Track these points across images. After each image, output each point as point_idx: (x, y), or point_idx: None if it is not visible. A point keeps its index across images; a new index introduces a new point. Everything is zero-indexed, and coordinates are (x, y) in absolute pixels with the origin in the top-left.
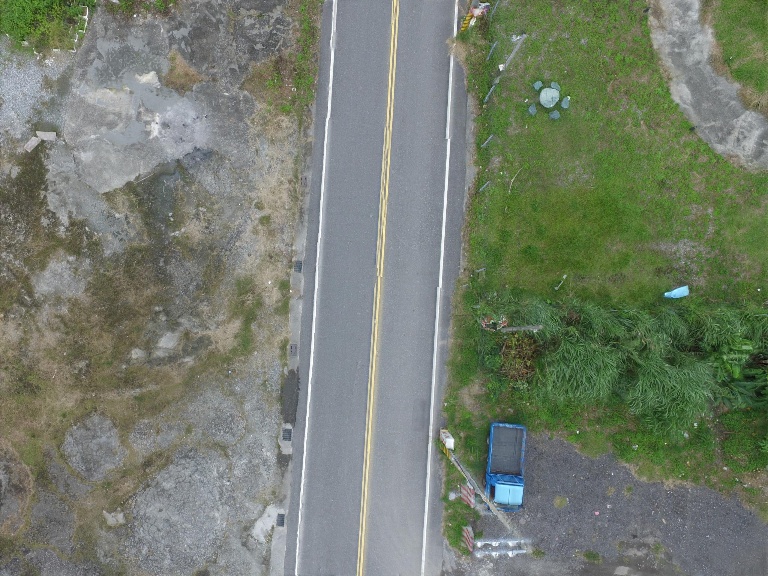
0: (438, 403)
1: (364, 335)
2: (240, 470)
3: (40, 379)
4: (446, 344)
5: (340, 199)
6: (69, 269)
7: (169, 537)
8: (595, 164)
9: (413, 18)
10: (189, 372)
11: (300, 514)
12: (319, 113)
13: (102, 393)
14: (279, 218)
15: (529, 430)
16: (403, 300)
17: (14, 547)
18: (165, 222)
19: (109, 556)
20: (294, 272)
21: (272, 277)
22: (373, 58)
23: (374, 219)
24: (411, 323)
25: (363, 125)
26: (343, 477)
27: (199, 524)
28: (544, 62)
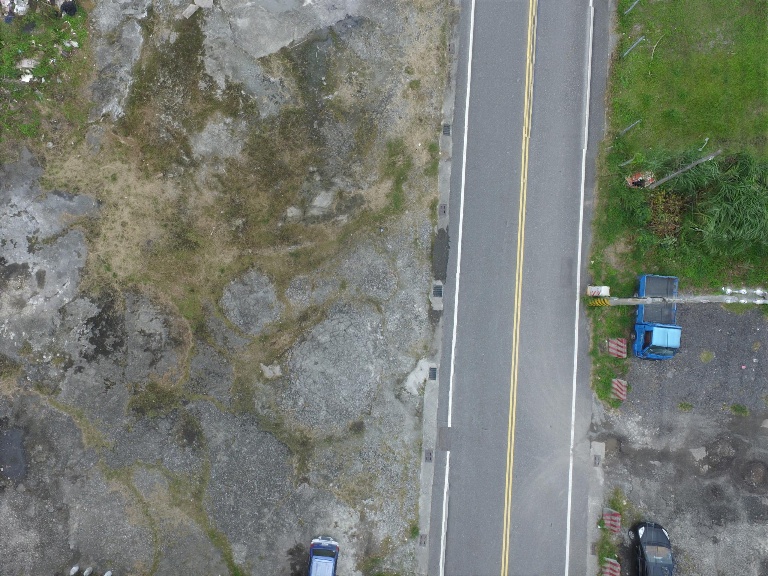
0: (585, 261)
1: (513, 195)
2: (393, 325)
3: (199, 236)
4: (592, 204)
5: (487, 65)
6: (226, 131)
7: (325, 389)
8: (735, 31)
9: None
10: (342, 230)
11: (453, 366)
12: None
13: (258, 250)
14: (428, 82)
15: (675, 286)
16: (550, 161)
17: (174, 398)
18: (318, 86)
19: (266, 407)
20: (443, 135)
21: (422, 139)
22: None
23: (521, 83)
24: (558, 183)
25: None
26: (494, 331)
27: (354, 377)
28: None
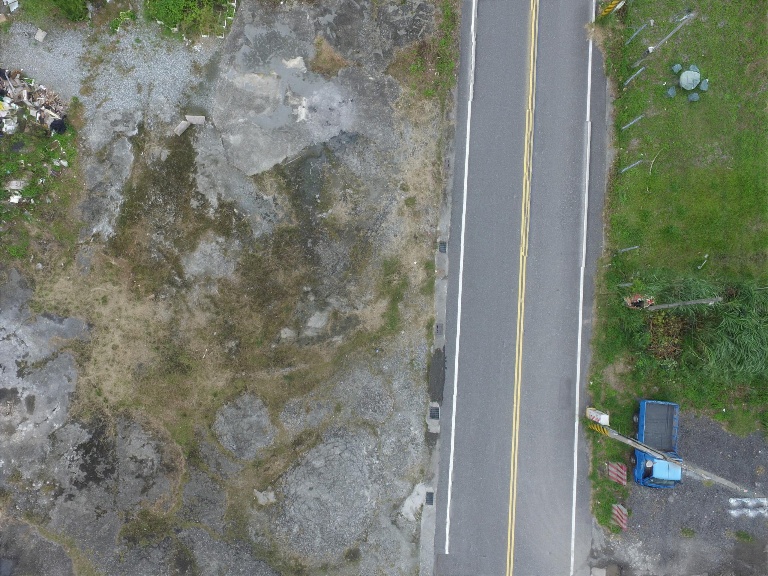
0: (584, 381)
1: (510, 314)
2: (389, 448)
3: (191, 358)
4: (590, 323)
5: (483, 181)
6: (218, 250)
7: (320, 515)
8: (734, 145)
9: (552, 4)
10: (337, 351)
11: (450, 492)
12: (461, 97)
13: (252, 372)
14: (424, 199)
15: None
16: (547, 280)
17: (166, 526)
18: (312, 204)
19: (260, 534)
20: (439, 252)
21: (418, 257)
22: (514, 43)
23: (518, 200)
24: (556, 302)
25: (505, 108)
26: (492, 455)
27: (349, 502)
28: (681, 46)
